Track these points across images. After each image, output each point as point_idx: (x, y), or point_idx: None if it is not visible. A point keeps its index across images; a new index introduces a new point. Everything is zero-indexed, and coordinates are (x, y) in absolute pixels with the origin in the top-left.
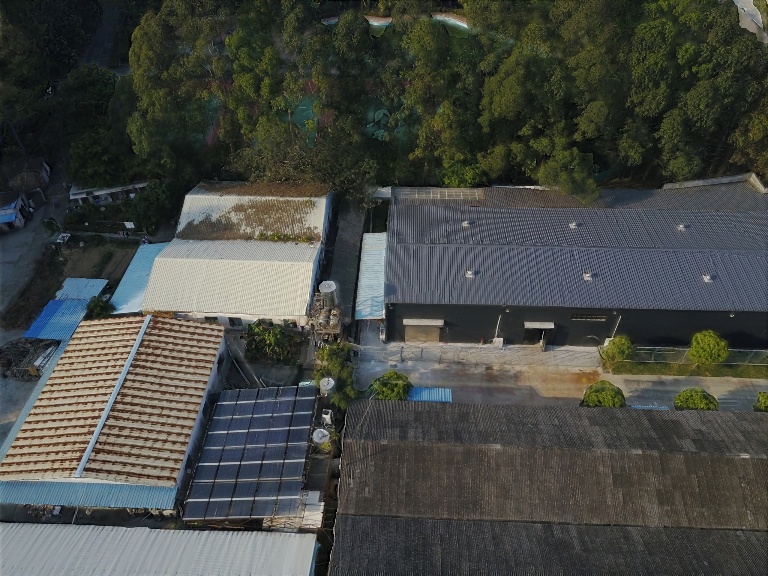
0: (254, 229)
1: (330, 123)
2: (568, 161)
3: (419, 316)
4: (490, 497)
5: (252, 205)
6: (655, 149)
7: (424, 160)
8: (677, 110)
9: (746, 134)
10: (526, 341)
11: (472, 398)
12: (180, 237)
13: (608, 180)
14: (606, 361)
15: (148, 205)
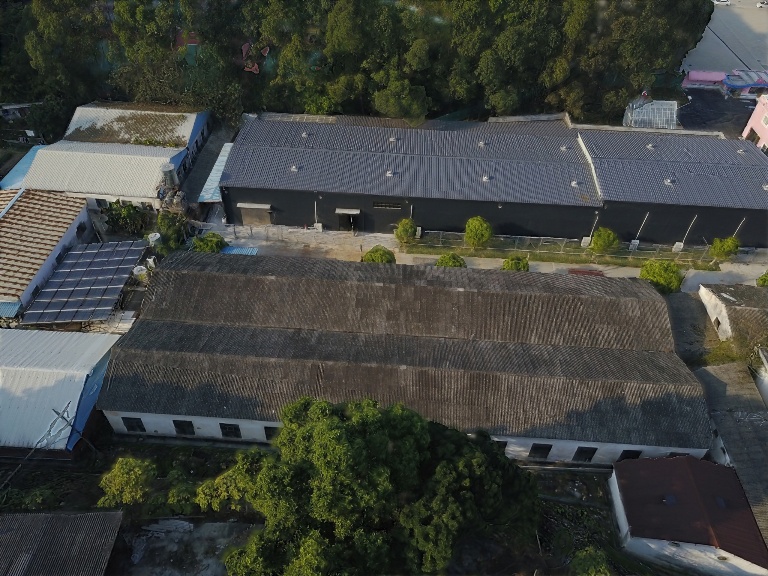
0: (131, 136)
1: (202, 50)
2: (400, 90)
3: (250, 201)
4: (259, 311)
5: (133, 117)
6: (478, 86)
7: (285, 88)
8: (490, 50)
9: (551, 75)
10: (342, 228)
11: None
12: (67, 139)
13: (459, 120)
14: (402, 243)
15: (43, 113)
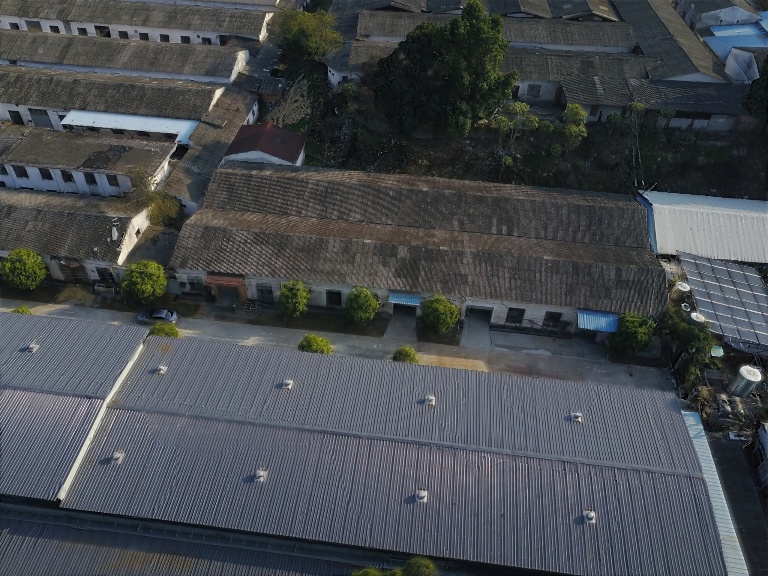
0: None
1: None
2: None
3: None
4: None
5: None
6: None
7: None
8: None
9: None
10: None
11: (547, 364)
12: None
13: None
14: None
15: None
